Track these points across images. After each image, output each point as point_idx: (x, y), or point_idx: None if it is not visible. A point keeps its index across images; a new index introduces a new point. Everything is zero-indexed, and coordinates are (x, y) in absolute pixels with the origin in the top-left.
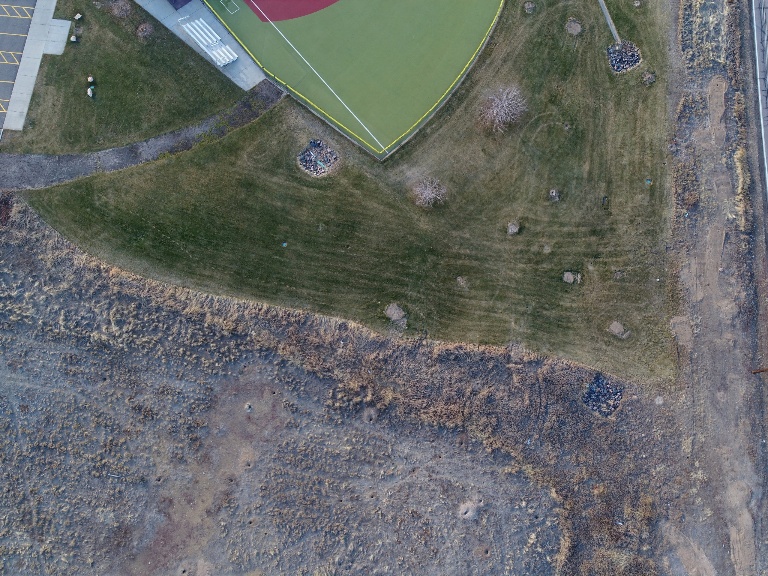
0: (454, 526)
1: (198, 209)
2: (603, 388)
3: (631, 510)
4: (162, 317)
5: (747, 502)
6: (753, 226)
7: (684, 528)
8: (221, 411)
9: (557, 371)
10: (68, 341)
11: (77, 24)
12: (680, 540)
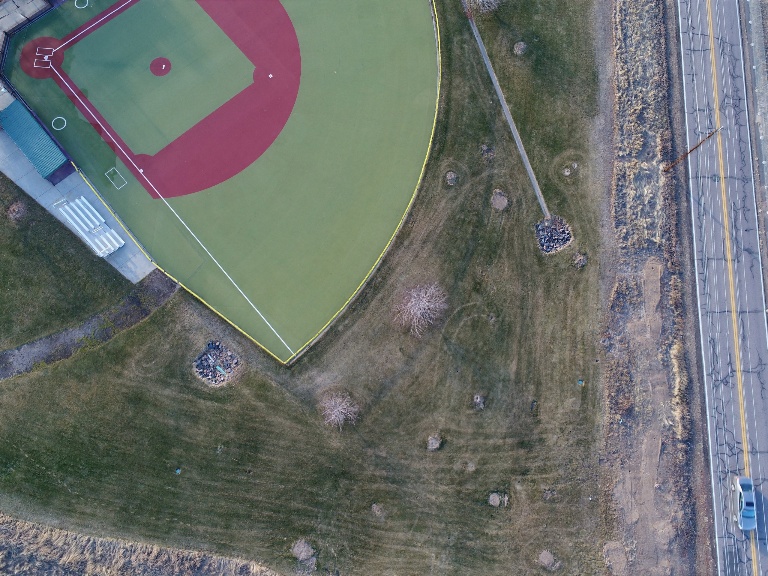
0: None
1: (78, 431)
2: None
3: None
4: (35, 568)
5: None
6: (691, 433)
7: None
8: None
9: None
10: None
11: None
12: None
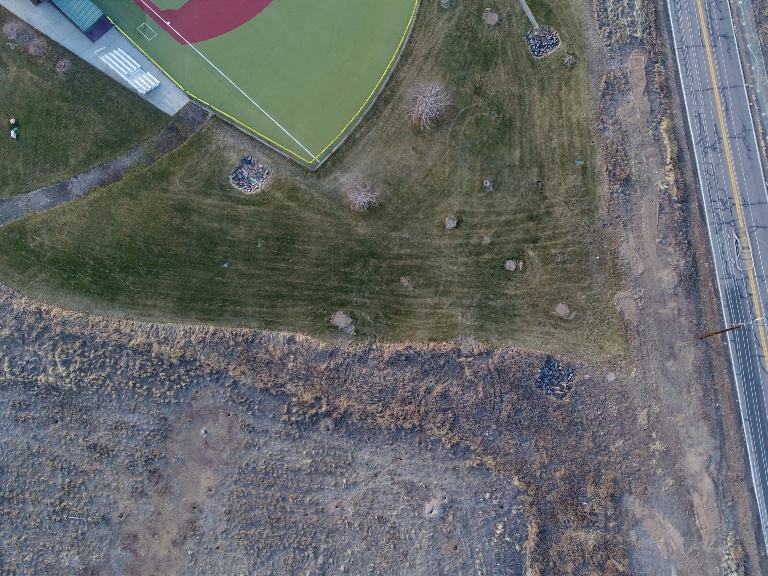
0: (421, 526)
1: (134, 239)
2: (555, 371)
3: (594, 489)
4: (108, 352)
5: (706, 467)
6: (685, 194)
7: (648, 500)
8: (177, 439)
9: (508, 360)
10: (15, 387)
11: None
12: (645, 512)
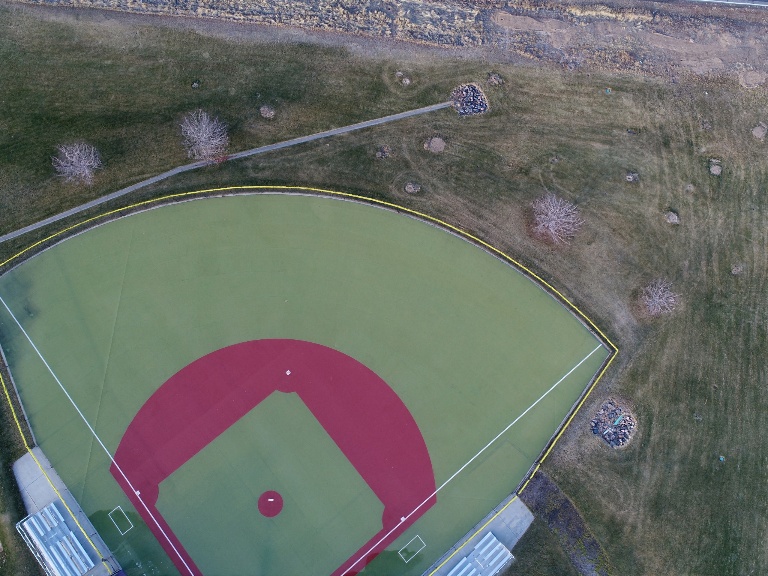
0: None
1: (694, 568)
2: None
3: None
4: None
5: None
6: None
7: None
8: None
9: None
10: None
11: None
12: None
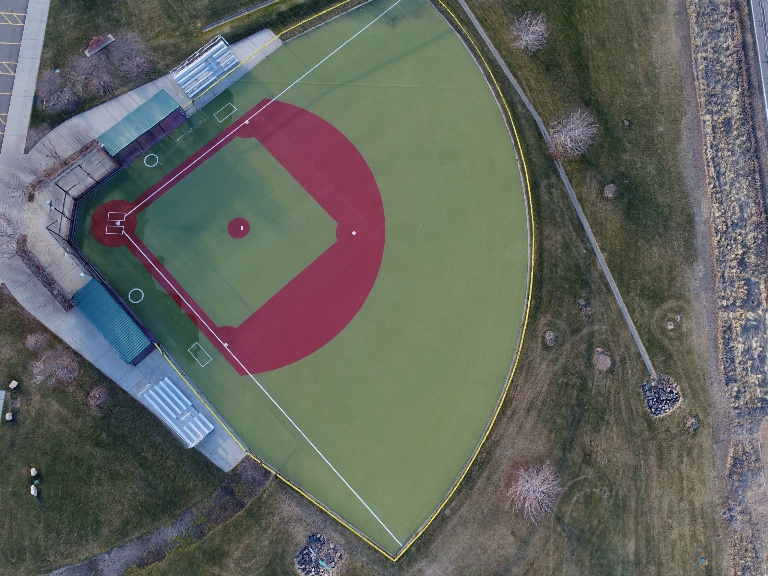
0: None
1: None
2: None
3: None
4: None
5: None
6: None
7: None
8: None
9: None
10: None
11: (13, 395)
12: None
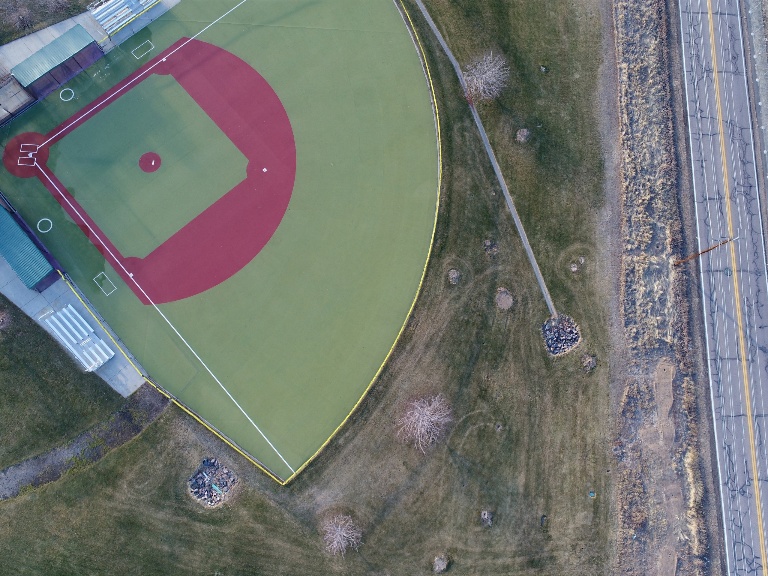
0: None
1: (68, 560)
2: None
3: None
4: None
5: None
6: (707, 548)
7: None
8: None
9: None
10: None
11: None
12: None
